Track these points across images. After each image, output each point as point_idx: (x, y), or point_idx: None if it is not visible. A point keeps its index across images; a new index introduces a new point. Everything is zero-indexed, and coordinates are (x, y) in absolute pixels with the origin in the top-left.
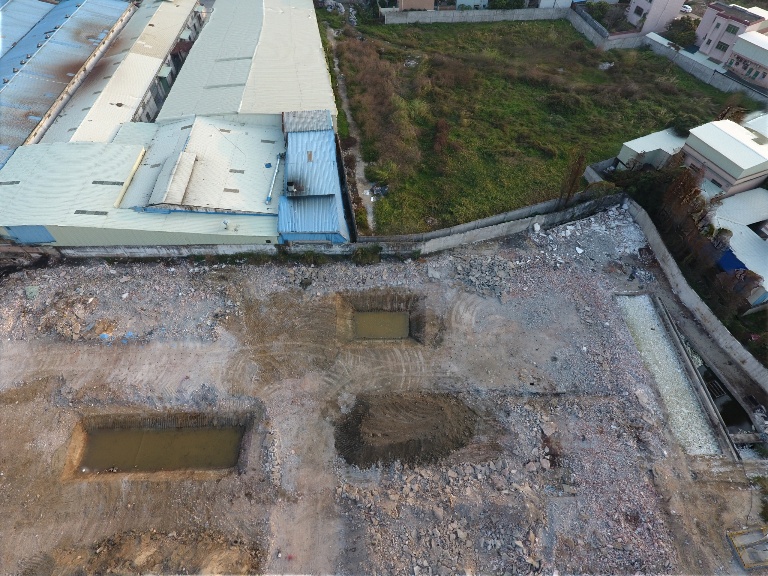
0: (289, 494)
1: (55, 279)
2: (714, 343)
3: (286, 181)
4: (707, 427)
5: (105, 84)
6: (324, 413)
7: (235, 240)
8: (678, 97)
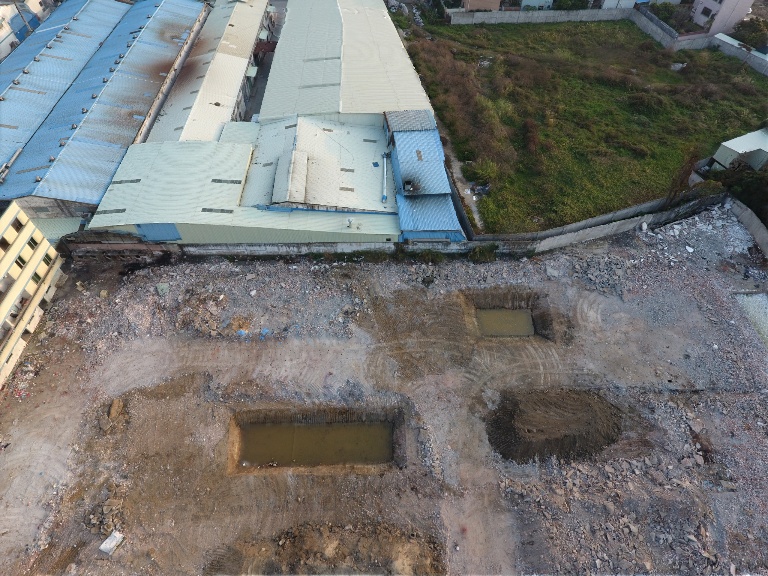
0: (454, 488)
1: (181, 276)
2: None
3: (400, 180)
4: None
5: (200, 84)
6: (472, 409)
7: (356, 238)
8: (758, 97)
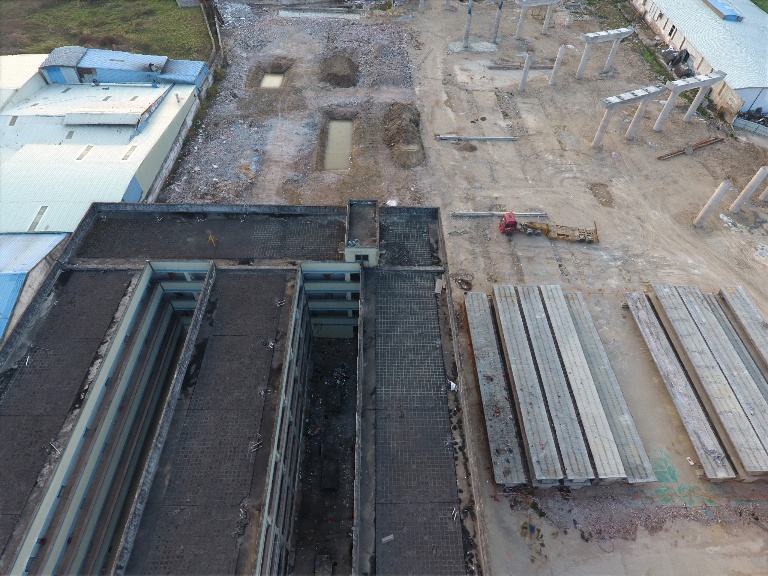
0: None
1: None
2: (310, 4)
3: (140, 73)
4: (348, 14)
5: None
6: (328, 90)
7: None
8: None
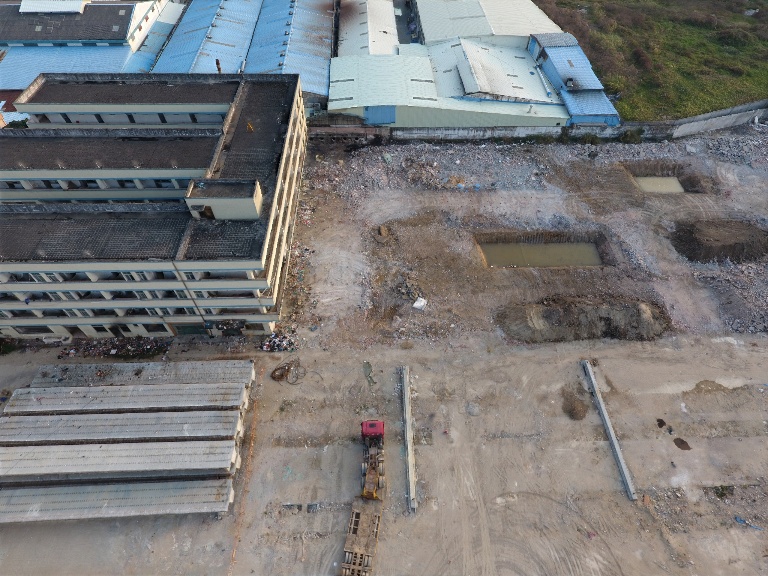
0: (659, 276)
1: (397, 152)
2: None
3: (560, 80)
4: None
5: (366, 17)
6: (656, 232)
7: (533, 122)
8: None
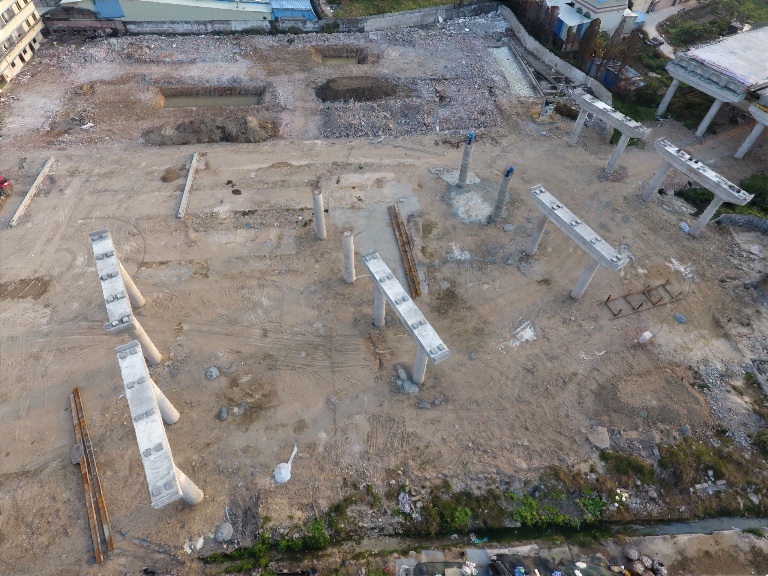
0: (291, 109)
1: None
2: (543, 63)
3: None
4: (531, 90)
5: None
6: (308, 85)
7: (243, 16)
8: None
